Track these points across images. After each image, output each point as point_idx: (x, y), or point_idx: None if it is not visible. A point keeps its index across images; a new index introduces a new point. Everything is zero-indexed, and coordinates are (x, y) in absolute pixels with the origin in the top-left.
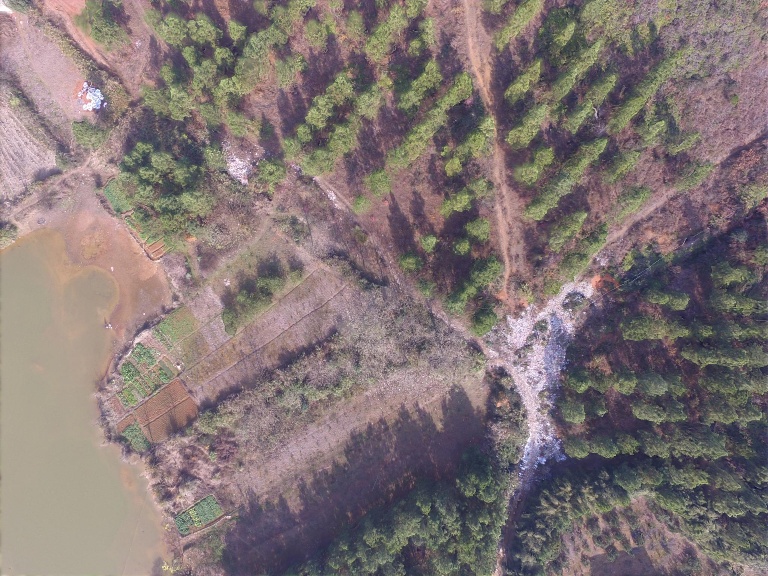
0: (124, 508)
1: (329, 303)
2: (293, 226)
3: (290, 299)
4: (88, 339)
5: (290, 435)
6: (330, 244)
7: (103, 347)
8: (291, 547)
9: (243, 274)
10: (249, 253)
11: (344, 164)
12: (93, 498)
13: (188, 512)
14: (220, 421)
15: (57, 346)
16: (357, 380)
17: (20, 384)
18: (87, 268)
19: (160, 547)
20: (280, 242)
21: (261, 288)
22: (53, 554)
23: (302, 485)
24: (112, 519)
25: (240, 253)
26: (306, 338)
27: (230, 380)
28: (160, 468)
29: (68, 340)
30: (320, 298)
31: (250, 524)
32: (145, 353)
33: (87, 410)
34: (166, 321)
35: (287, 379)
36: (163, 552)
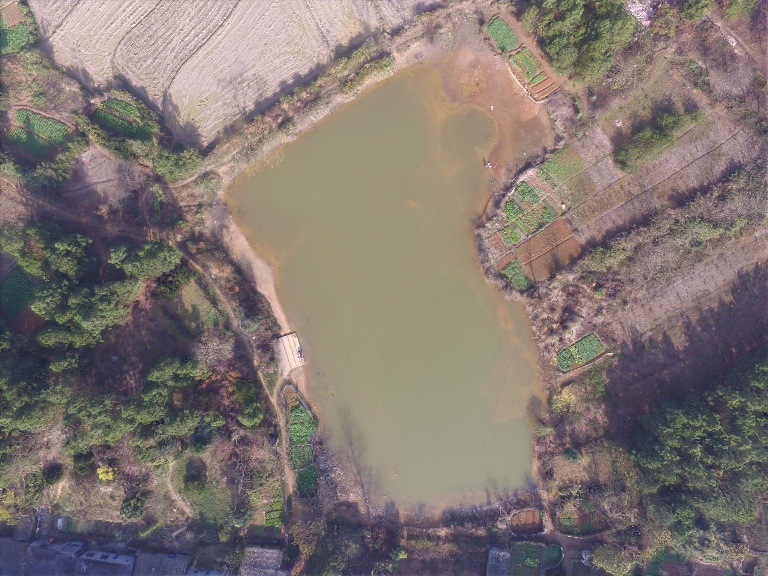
0: (498, 347)
1: (722, 146)
2: (693, 69)
3: (684, 141)
4: (464, 177)
5: (676, 274)
6: (726, 89)
7: (480, 186)
8: (674, 382)
9: (637, 115)
10: (643, 95)
11: (747, 11)
12: (466, 337)
13: (569, 349)
14: (613, 257)
15: (432, 183)
16: (750, 220)
17: (392, 220)
18: (465, 106)
19: (535, 385)
20: (677, 85)
21: (665, 126)
22: (423, 392)
23: (687, 322)
24: (485, 358)
25: (634, 95)
26: (698, 180)
27: (617, 220)
28: (544, 305)
29: (444, 177)
30: (713, 141)
31: (633, 361)
32: (530, 191)
33: (463, 248)
34: (551, 160)
35: (684, 216)
36: (538, 390)
